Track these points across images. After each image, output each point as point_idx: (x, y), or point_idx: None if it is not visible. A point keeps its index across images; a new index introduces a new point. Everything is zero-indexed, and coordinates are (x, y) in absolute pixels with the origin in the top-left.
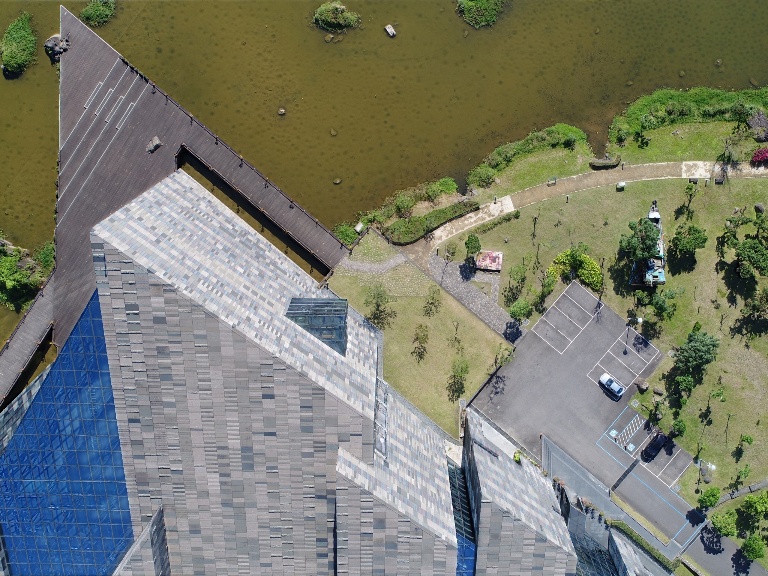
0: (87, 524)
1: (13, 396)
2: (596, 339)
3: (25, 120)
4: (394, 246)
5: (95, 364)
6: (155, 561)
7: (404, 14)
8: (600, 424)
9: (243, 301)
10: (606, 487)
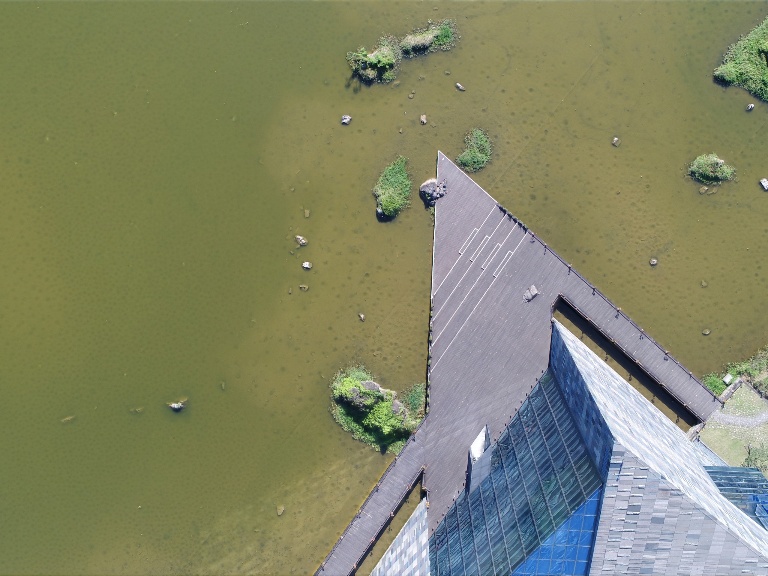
0: None
1: None
2: None
3: (396, 263)
4: (766, 400)
5: (573, 554)
6: None
7: None
8: None
9: (701, 487)
10: None
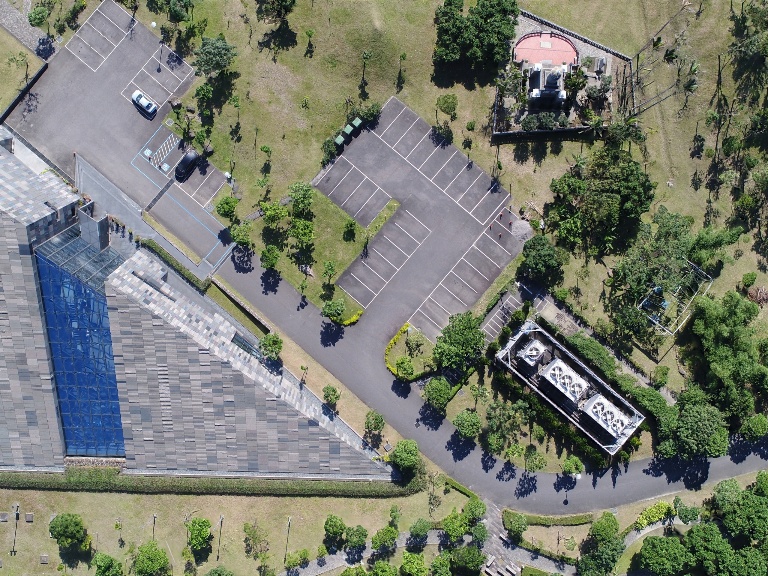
0: None
1: None
2: (130, 57)
3: None
4: None
5: None
6: None
7: None
8: (134, 143)
9: None
10: (140, 207)
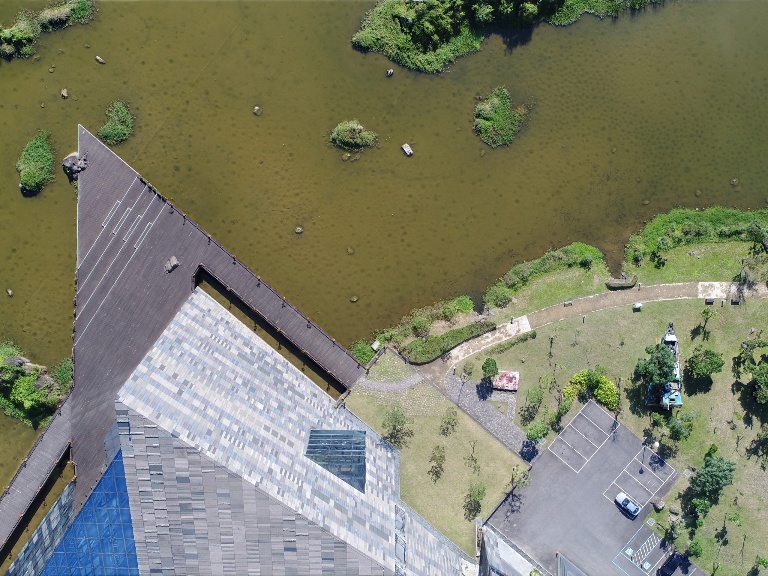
0: None
1: (30, 512)
2: (612, 458)
3: (43, 237)
4: (411, 366)
5: (118, 517)
6: None
7: (421, 133)
8: (616, 542)
9: (264, 448)
10: None
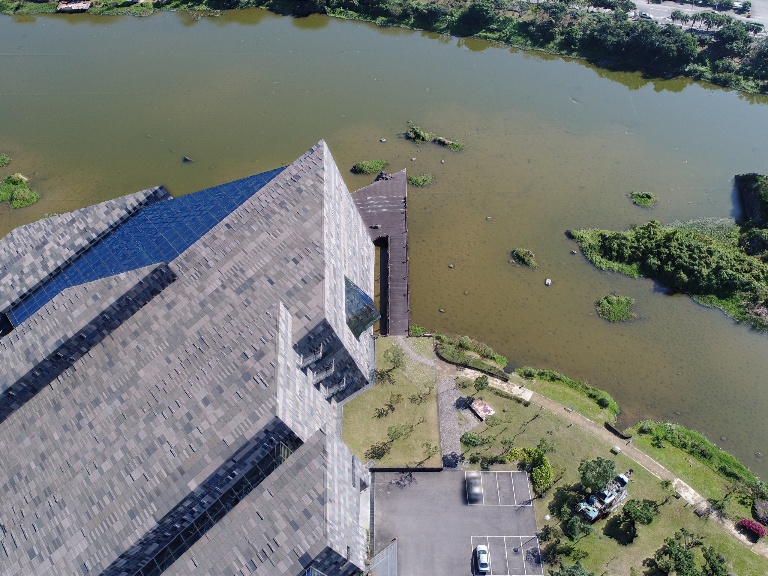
0: (137, 263)
1: None
2: (503, 520)
3: None
4: (435, 355)
5: None
6: (141, 283)
7: (564, 282)
8: None
9: None
10: None
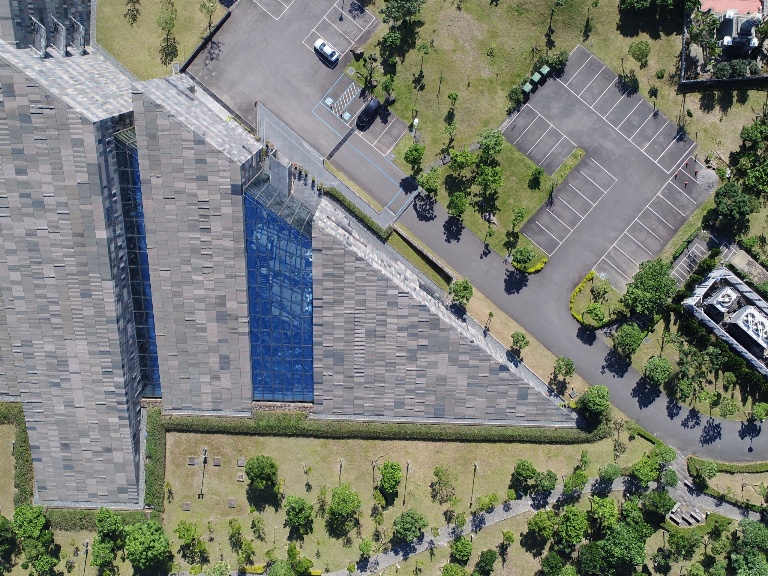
0: None
1: None
2: (312, 5)
3: None
4: None
5: None
6: None
7: None
8: (316, 92)
9: None
10: (321, 156)
